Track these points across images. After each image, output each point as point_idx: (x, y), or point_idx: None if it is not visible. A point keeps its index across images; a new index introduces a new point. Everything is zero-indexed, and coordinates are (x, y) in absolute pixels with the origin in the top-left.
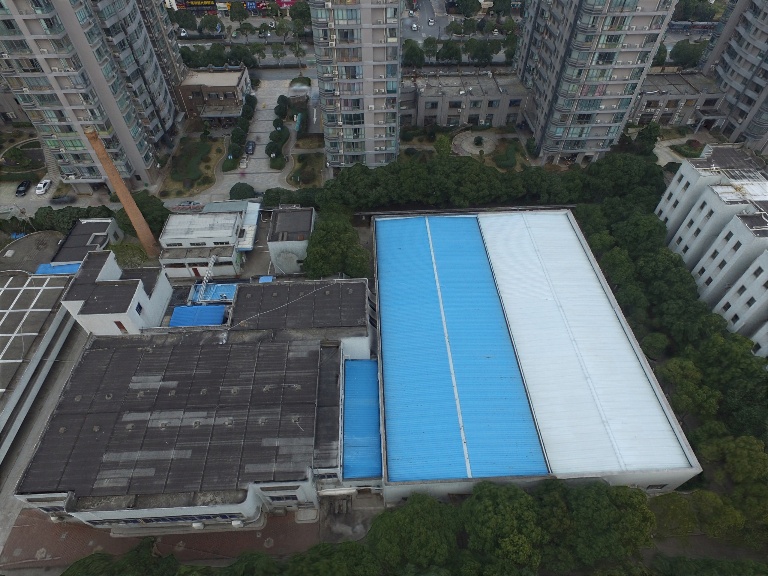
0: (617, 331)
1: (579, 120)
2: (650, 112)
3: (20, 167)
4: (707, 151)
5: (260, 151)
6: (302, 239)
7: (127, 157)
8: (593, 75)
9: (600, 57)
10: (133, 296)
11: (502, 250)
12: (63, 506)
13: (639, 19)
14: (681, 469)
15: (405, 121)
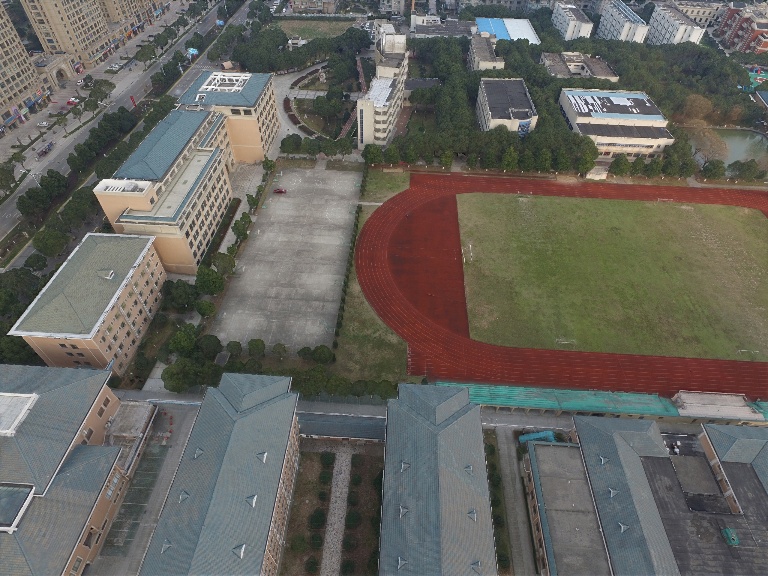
0: None
1: (536, 2)
2: None
3: (360, 9)
4: (563, 1)
5: (433, 12)
6: (457, 19)
7: (400, 4)
8: None
9: None
10: (426, 15)
11: None
12: (422, 39)
13: None
14: (538, 43)
15: None
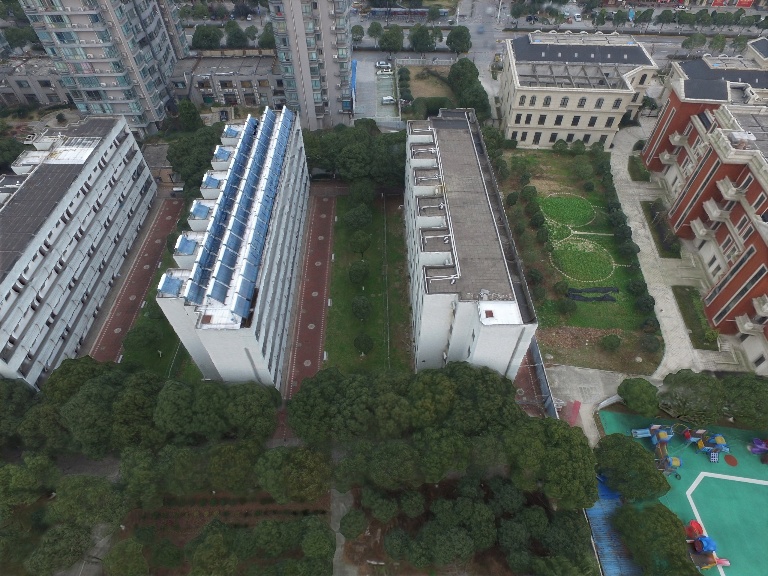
0: None
1: (91, 97)
2: (230, 92)
3: None
4: None
5: None
6: None
7: None
8: (67, 53)
9: (59, 36)
10: None
11: None
12: None
13: (67, 0)
14: None
15: (12, 99)
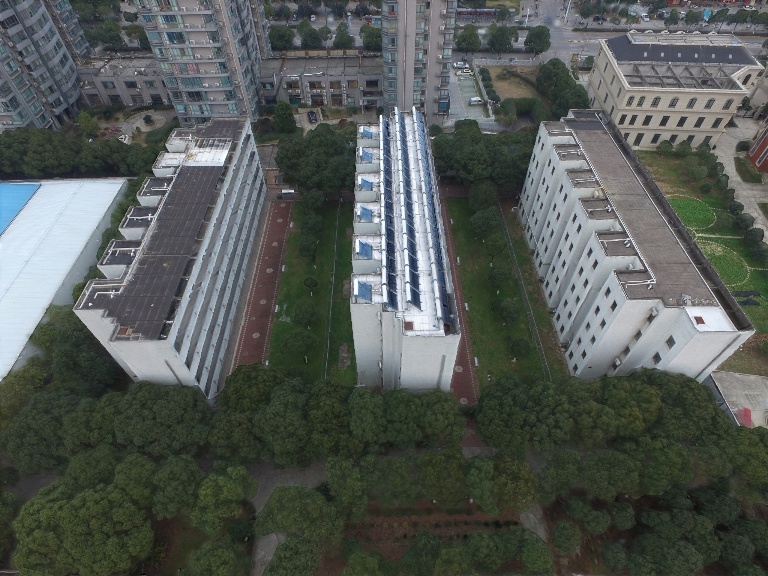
0: (58, 283)
1: (192, 98)
2: (317, 93)
3: None
4: None
5: None
6: None
7: None
8: (175, 54)
9: (170, 37)
10: None
11: (32, 213)
12: None
13: (184, 0)
14: None
15: (95, 100)
